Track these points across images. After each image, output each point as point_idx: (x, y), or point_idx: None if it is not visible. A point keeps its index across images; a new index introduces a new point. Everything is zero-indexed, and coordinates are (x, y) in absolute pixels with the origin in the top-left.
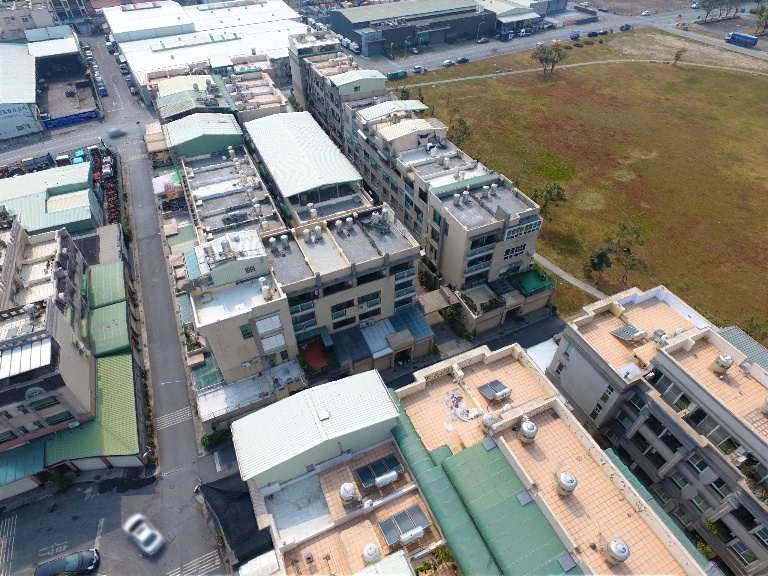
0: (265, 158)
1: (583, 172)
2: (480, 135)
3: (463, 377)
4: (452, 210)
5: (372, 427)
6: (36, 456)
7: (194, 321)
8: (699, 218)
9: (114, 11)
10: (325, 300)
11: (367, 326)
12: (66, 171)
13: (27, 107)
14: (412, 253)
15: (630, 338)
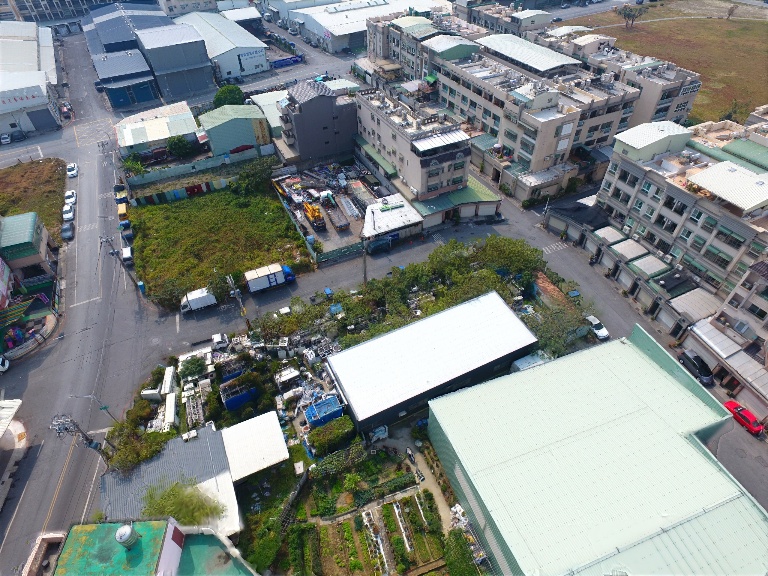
0: (509, 55)
1: None
2: None
3: None
4: None
5: (683, 136)
6: (446, 201)
7: (531, 124)
8: None
9: None
10: (589, 121)
11: (599, 148)
12: (334, 83)
13: (264, 50)
14: (635, 95)
15: None
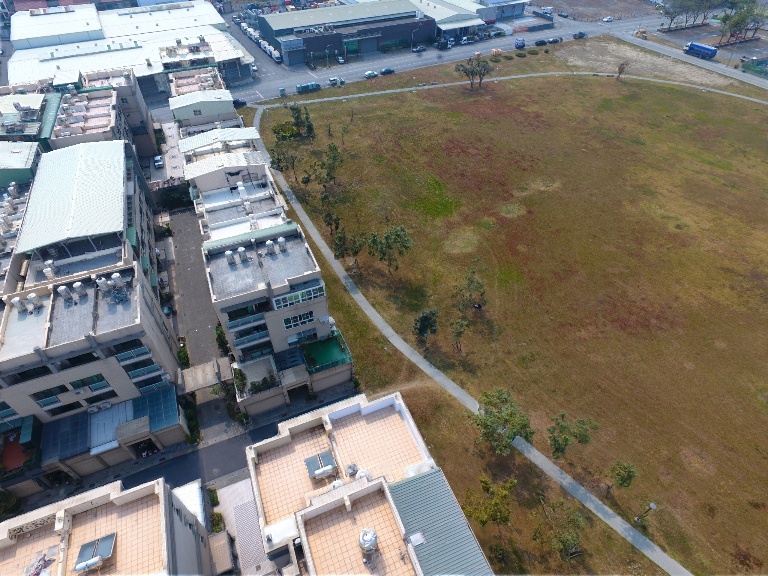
0: (31, 200)
1: (467, 206)
2: (371, 159)
3: (77, 526)
4: (222, 270)
5: None
6: None
7: None
8: (578, 266)
9: (22, 16)
10: (14, 389)
11: (101, 410)
12: None
13: None
14: (132, 331)
15: (314, 474)
